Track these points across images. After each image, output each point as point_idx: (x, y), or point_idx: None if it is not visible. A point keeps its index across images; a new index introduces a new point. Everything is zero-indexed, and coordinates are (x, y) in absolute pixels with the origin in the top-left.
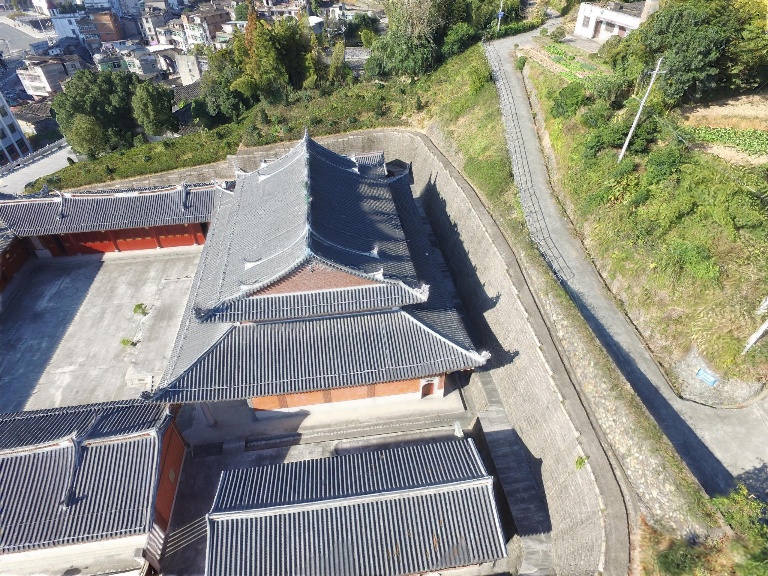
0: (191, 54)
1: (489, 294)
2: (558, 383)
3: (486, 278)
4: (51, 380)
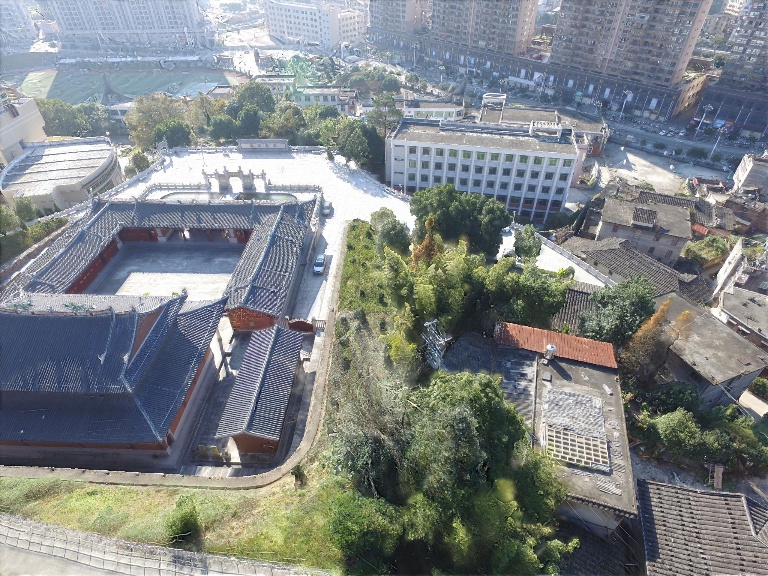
0: (746, 250)
1: None
2: None
3: None
4: (148, 276)
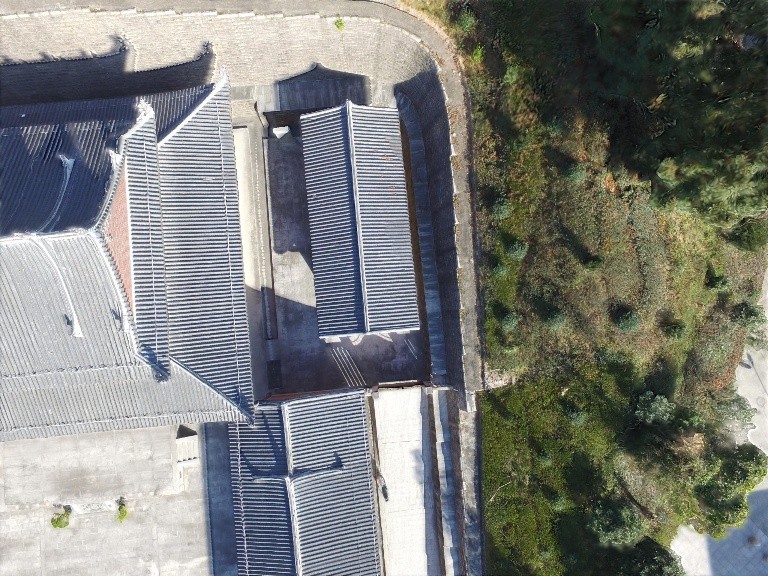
0: None
1: (113, 52)
2: (264, 12)
3: (85, 48)
4: None
